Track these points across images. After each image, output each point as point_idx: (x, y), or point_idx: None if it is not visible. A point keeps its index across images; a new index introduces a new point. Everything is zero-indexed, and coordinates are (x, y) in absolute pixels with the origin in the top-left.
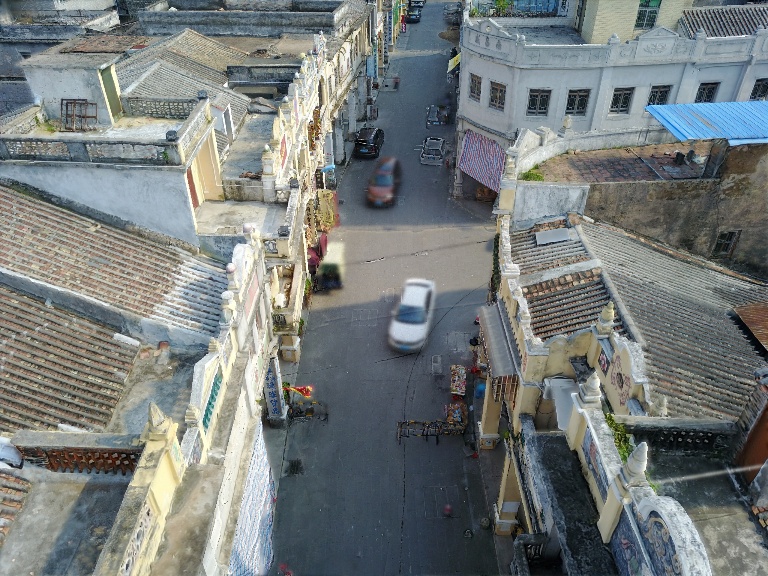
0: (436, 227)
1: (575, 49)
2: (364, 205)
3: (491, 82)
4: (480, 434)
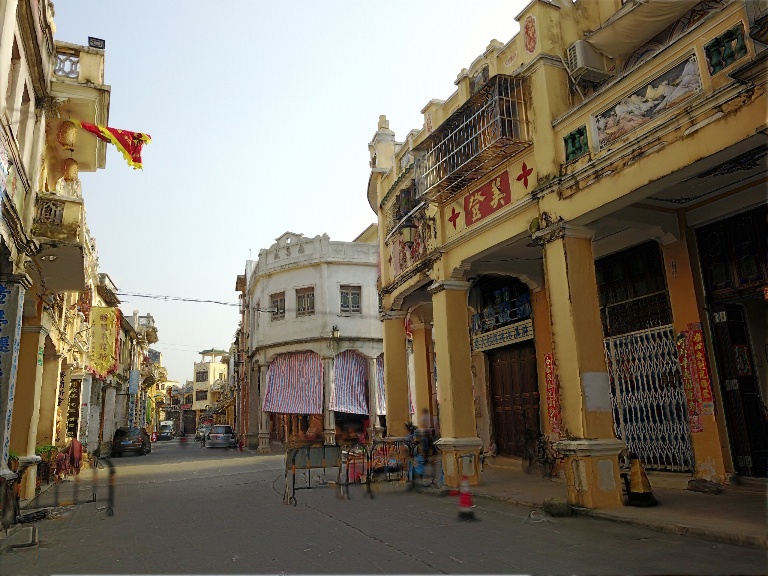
0: (247, 457)
1: (376, 246)
2: (134, 461)
3: (296, 291)
4: (449, 441)
